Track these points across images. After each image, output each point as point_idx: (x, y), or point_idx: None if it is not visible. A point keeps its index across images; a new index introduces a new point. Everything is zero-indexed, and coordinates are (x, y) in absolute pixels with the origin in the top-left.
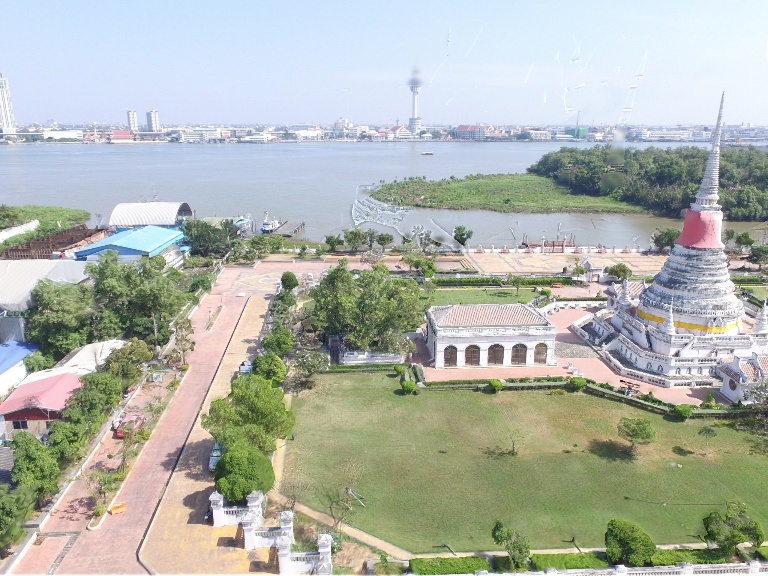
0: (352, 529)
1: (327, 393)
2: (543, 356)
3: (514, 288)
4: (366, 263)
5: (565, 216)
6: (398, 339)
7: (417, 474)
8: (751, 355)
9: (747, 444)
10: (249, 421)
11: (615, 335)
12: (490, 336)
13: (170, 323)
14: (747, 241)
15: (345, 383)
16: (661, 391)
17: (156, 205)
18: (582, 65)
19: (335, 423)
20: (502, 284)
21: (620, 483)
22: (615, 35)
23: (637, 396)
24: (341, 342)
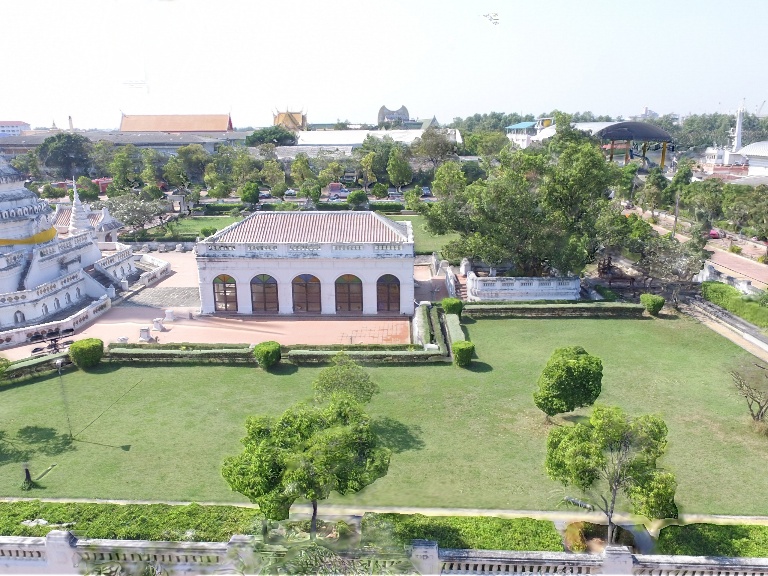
0: None
1: None
2: None
3: None
4: None
5: None
6: None
7: None
8: None
9: None
10: None
11: None
12: None
13: None
14: None
15: None
16: None
17: None
18: None
19: None
20: None
21: None
22: None
23: None
24: None
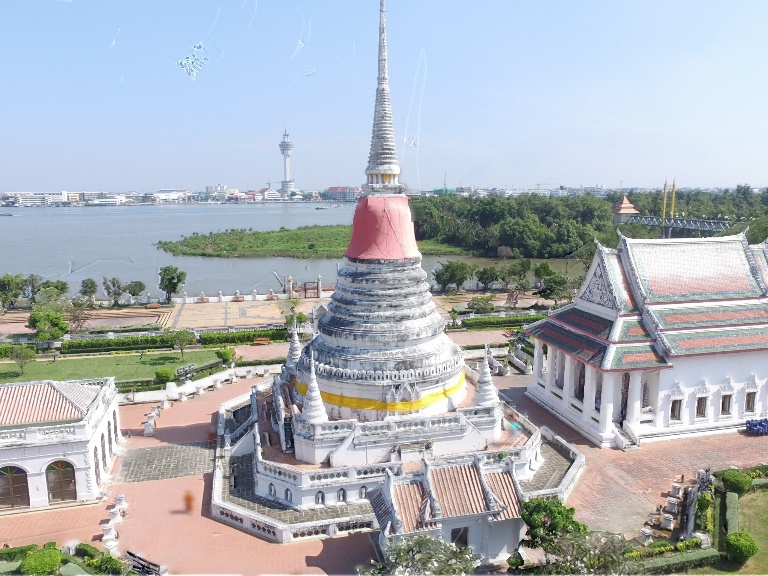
0: None
1: None
2: (68, 486)
3: (193, 350)
4: None
5: None
6: None
7: None
8: (466, 450)
9: None
10: None
11: None
12: None
13: None
14: (547, 273)
15: None
16: (257, 555)
17: None
18: (250, 7)
19: None
20: None
21: None
22: None
23: None
24: None
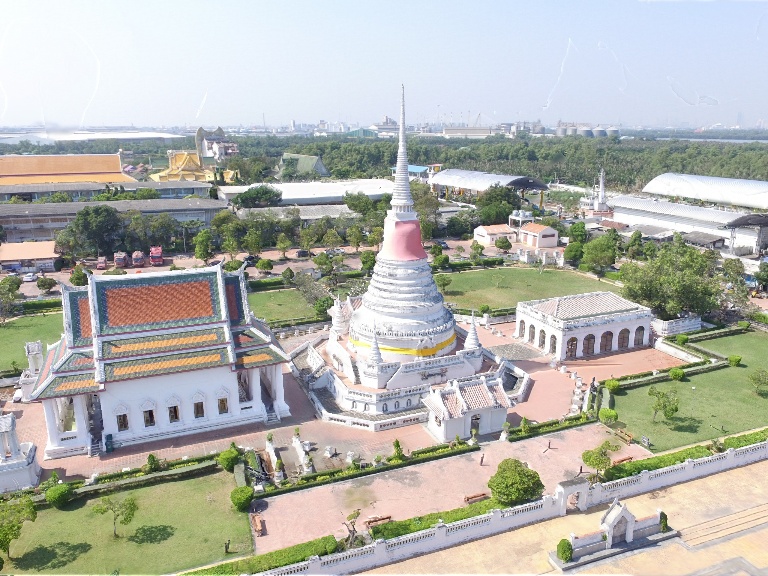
0: None
1: None
2: None
3: None
4: None
5: None
6: None
7: None
8: None
9: None
10: None
11: None
12: None
13: None
14: None
15: None
16: None
17: None
18: None
19: None
20: (720, 446)
21: None
22: None
23: None
24: None
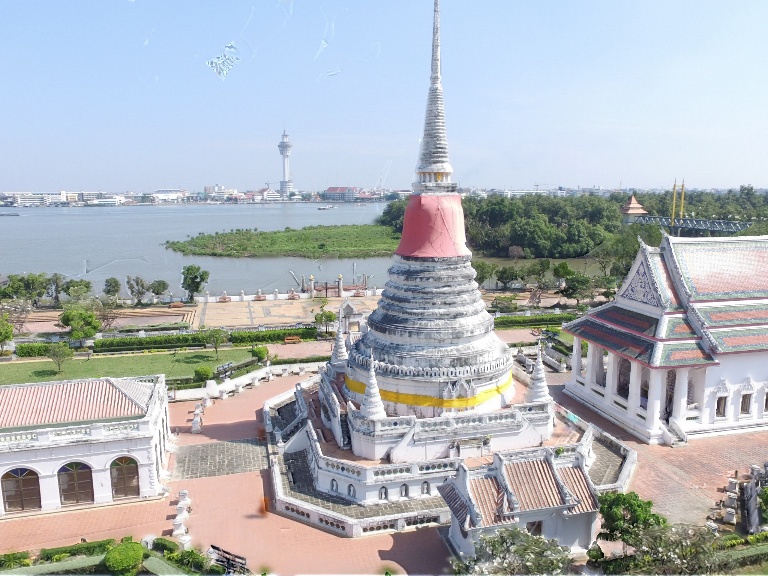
0: None
1: None
2: (131, 482)
3: (225, 348)
4: None
5: (385, 260)
6: None
7: None
8: (521, 446)
9: None
10: None
11: (306, 422)
12: None
13: None
14: (566, 273)
15: None
16: (330, 549)
17: None
18: (285, 6)
19: None
20: None
21: None
22: None
23: None
24: None
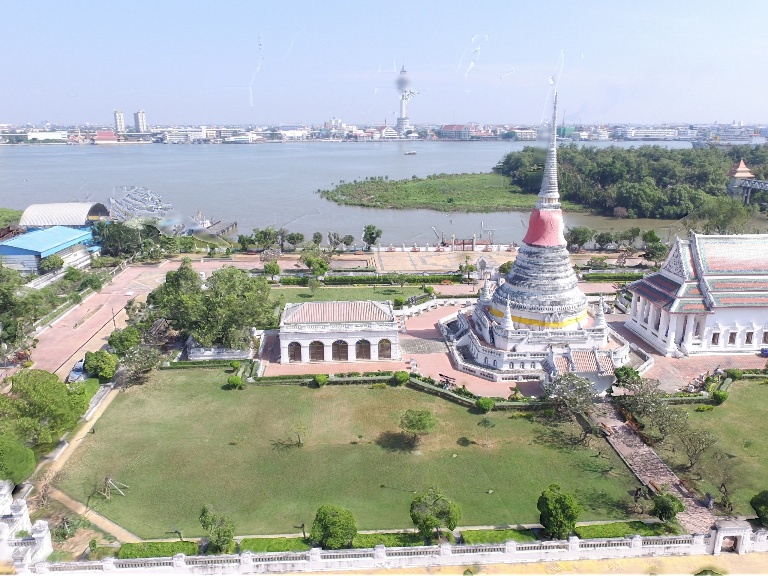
0: (98, 517)
1: (155, 388)
2: (387, 352)
3: (404, 286)
4: (265, 262)
5: (504, 215)
6: (242, 336)
7: (194, 465)
8: None
9: (533, 435)
10: (26, 414)
11: (468, 331)
12: (332, 332)
13: (36, 321)
14: (653, 239)
15: (179, 379)
16: (487, 385)
17: (68, 206)
18: (456, 66)
19: (145, 417)
20: (393, 282)
21: (385, 472)
22: (479, 37)
23: (453, 389)
24: (192, 339)
